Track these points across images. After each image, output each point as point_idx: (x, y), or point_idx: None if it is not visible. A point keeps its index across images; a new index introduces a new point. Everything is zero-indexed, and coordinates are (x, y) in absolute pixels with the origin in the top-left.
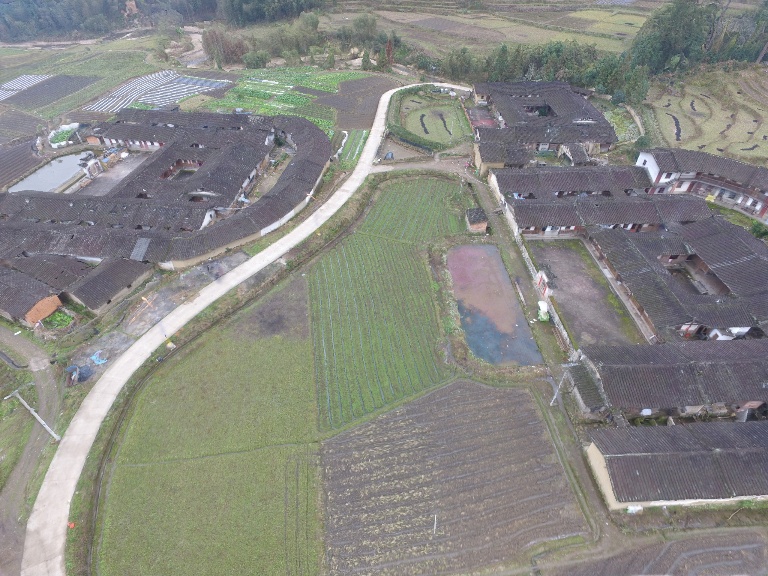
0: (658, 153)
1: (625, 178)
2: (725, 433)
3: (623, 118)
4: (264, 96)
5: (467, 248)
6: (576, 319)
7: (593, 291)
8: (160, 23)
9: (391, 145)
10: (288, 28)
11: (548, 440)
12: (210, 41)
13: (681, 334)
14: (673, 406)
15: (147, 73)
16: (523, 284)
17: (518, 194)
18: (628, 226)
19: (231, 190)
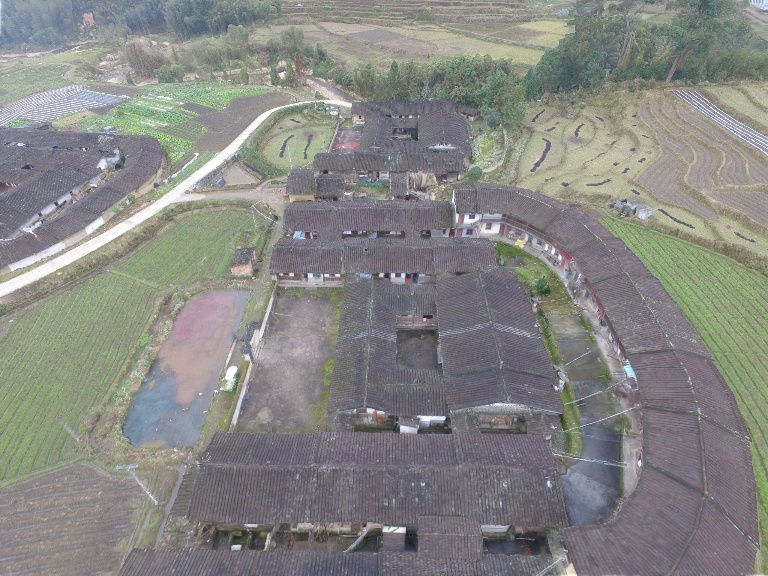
0: (460, 190)
1: (426, 217)
2: (288, 569)
3: (494, 143)
4: (146, 113)
5: (216, 294)
6: (269, 390)
7: (314, 354)
8: (99, 36)
9: (234, 169)
10: (213, 41)
11: (119, 552)
12: (130, 55)
13: (369, 418)
14: (265, 522)
15: (54, 88)
16: (242, 342)
17: (303, 232)
18: (401, 275)
19: (17, 218)
